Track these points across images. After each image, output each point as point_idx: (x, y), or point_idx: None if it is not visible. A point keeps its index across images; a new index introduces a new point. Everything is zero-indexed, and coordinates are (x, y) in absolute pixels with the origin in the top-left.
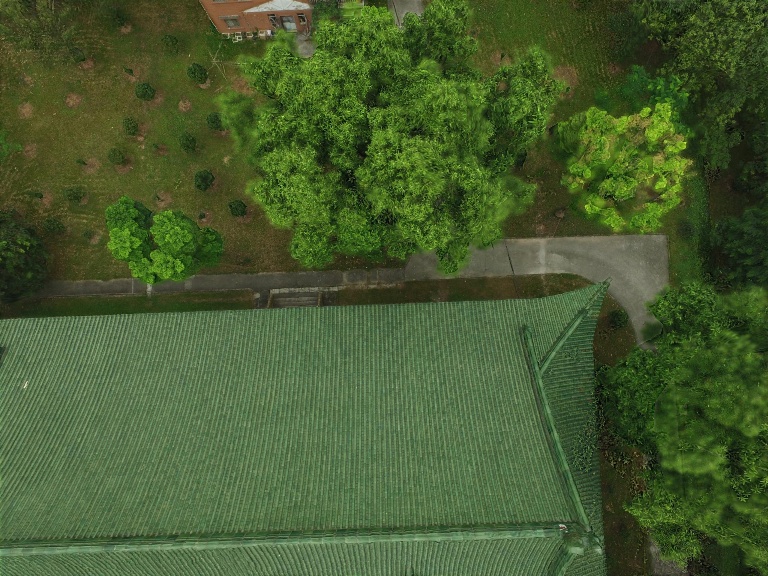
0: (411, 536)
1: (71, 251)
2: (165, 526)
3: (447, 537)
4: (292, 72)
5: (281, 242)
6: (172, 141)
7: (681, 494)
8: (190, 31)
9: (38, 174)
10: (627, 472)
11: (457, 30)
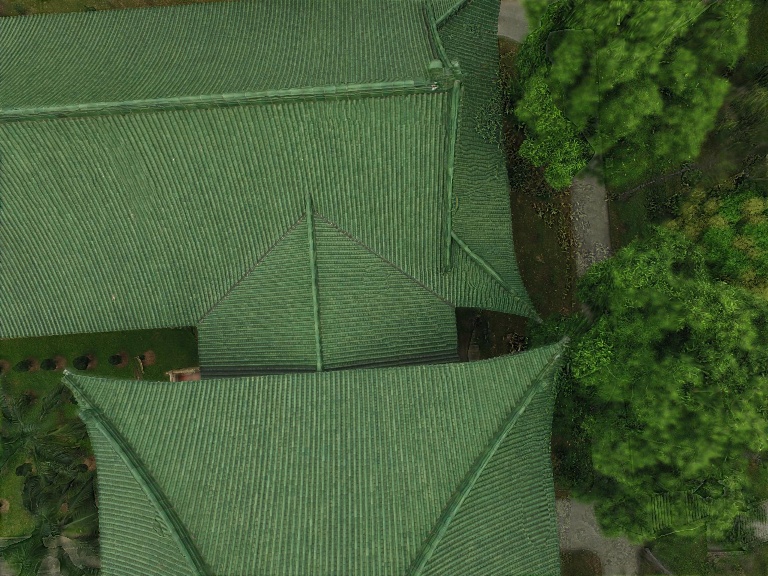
0: (286, 89)
1: None
2: None
3: (320, 87)
4: None
5: None
6: None
7: (608, 243)
8: None
9: None
10: (555, 222)
11: None
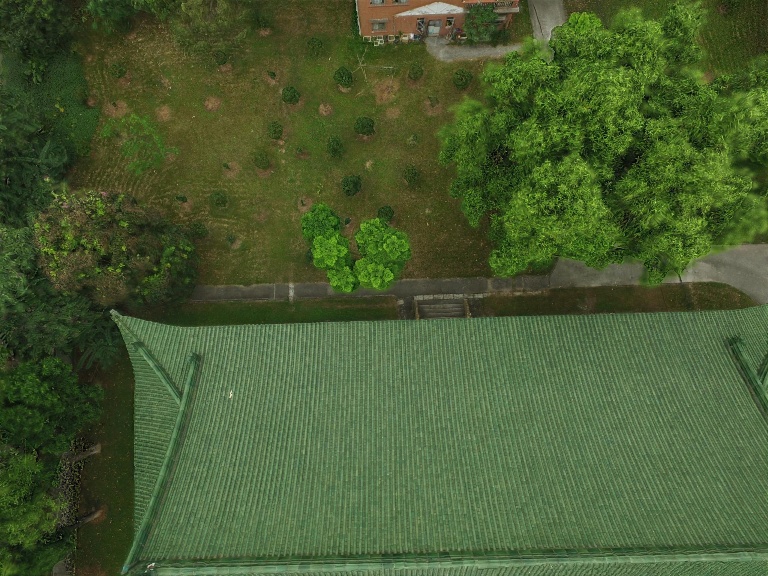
0: (697, 556)
1: (212, 255)
2: (429, 543)
3: (735, 558)
4: (552, 81)
5: (425, 248)
6: (313, 145)
7: None
8: (330, 34)
9: (177, 177)
10: None
11: (689, 38)
